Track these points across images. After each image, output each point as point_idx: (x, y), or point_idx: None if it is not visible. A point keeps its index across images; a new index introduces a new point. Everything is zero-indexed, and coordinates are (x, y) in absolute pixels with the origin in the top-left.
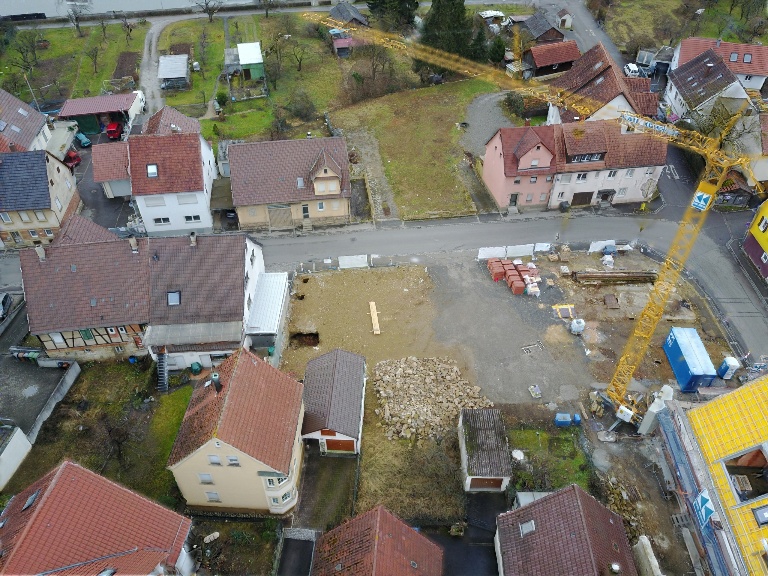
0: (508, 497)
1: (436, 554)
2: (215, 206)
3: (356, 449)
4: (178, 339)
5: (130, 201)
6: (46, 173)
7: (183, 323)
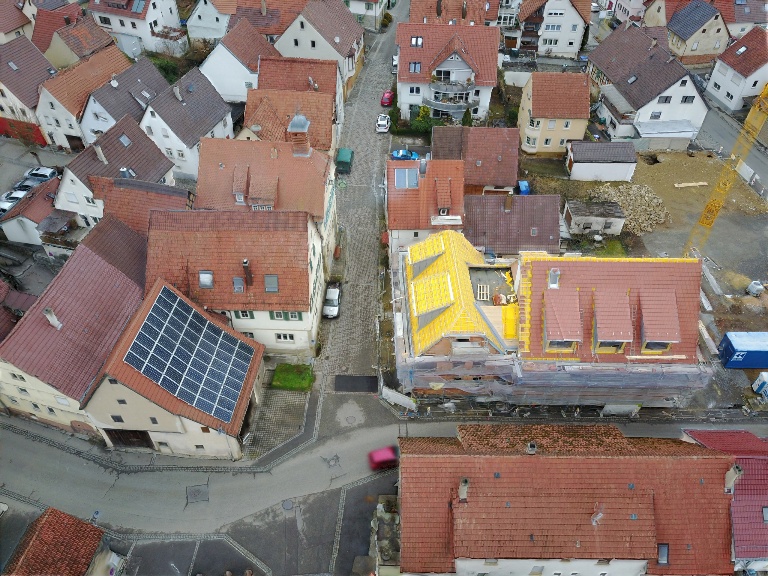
0: None
1: (512, 180)
2: (748, 99)
3: (571, 171)
4: (609, 95)
5: (713, 59)
6: (706, 22)
7: (621, 93)
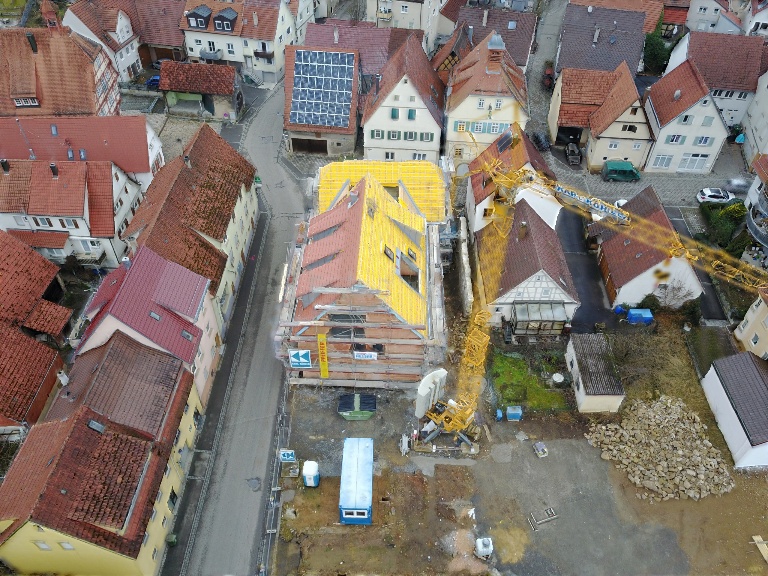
0: (563, 350)
1: None
2: None
3: None
4: None
5: None
6: None
7: None
